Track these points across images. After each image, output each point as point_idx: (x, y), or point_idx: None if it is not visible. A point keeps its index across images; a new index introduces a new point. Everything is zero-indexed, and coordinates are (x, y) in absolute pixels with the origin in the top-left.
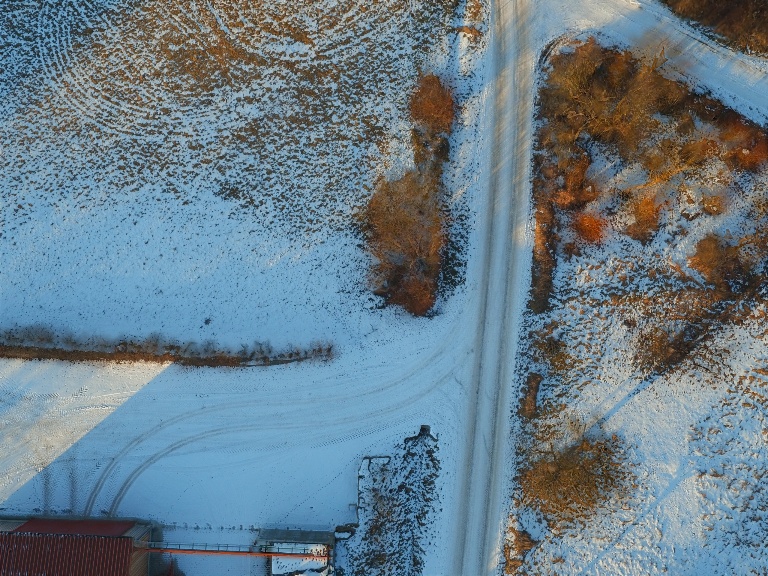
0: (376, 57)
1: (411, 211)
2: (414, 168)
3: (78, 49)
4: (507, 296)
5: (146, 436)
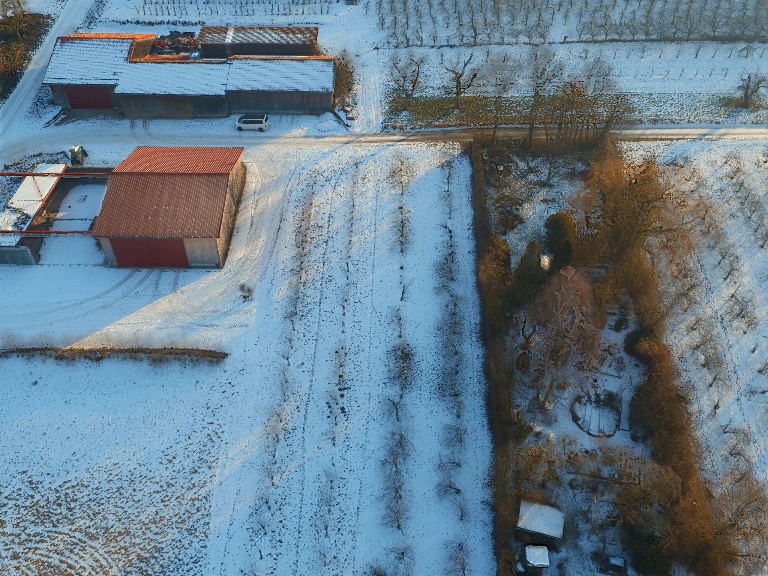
0: None
1: None
2: None
3: None
4: None
5: (99, 309)
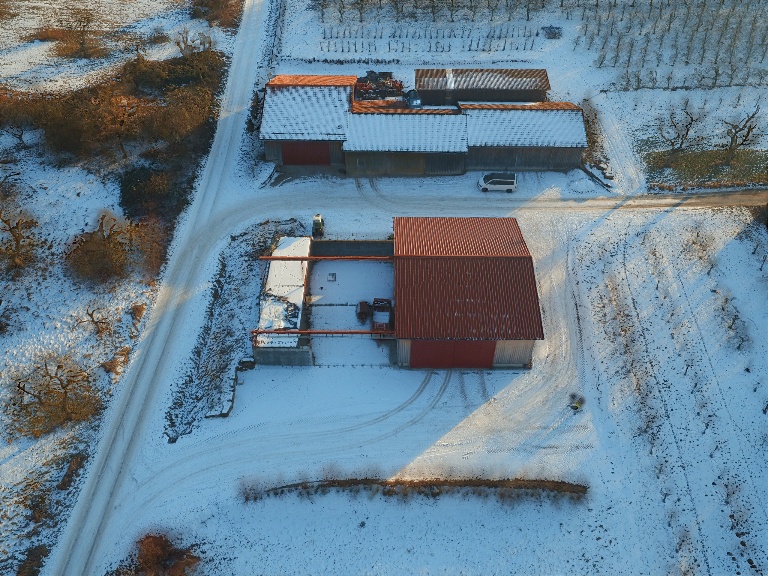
0: None
1: None
2: None
3: None
4: (67, 561)
5: (408, 425)
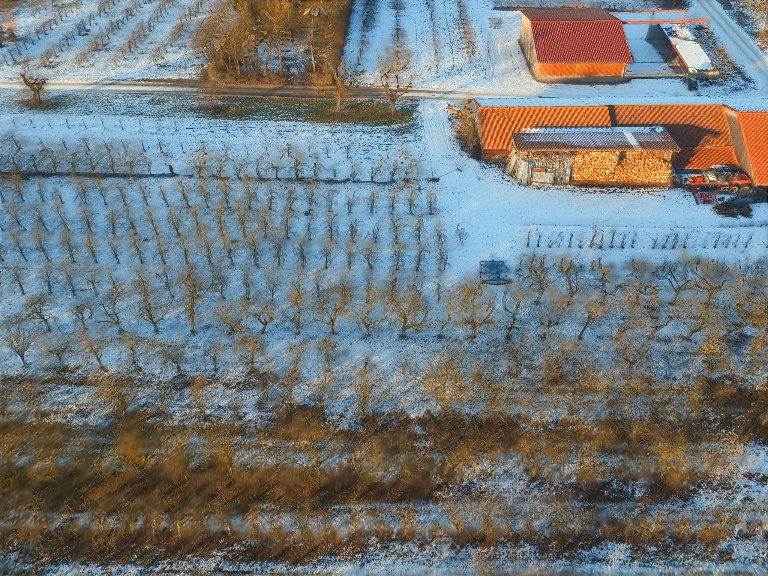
0: None
1: None
2: None
3: None
4: (713, 7)
5: None
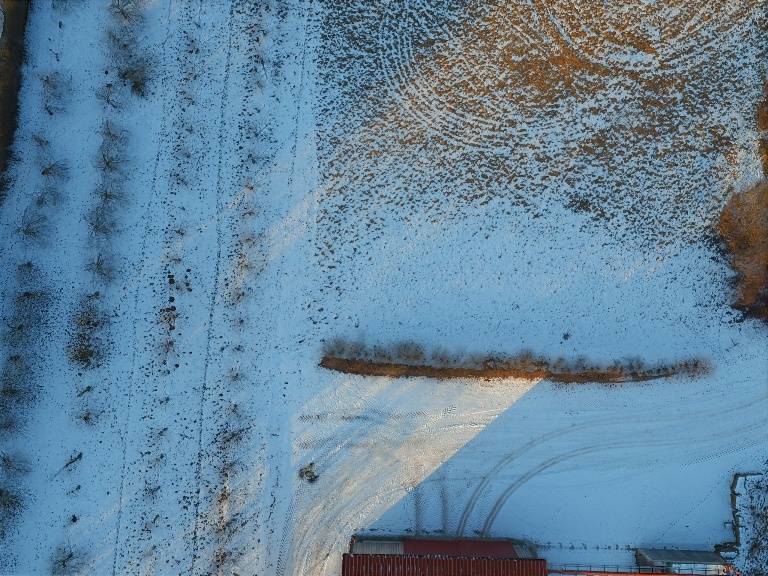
0: (720, 66)
1: (763, 223)
2: (763, 179)
3: (420, 60)
4: None
5: (517, 454)
